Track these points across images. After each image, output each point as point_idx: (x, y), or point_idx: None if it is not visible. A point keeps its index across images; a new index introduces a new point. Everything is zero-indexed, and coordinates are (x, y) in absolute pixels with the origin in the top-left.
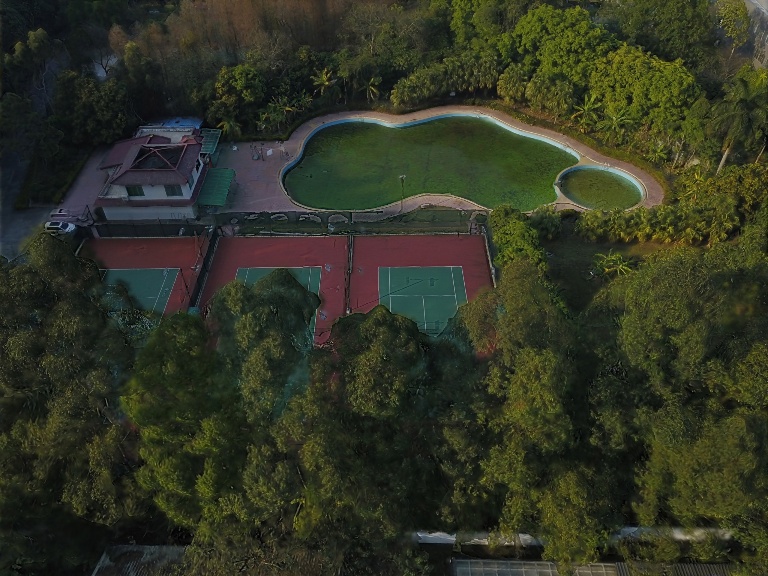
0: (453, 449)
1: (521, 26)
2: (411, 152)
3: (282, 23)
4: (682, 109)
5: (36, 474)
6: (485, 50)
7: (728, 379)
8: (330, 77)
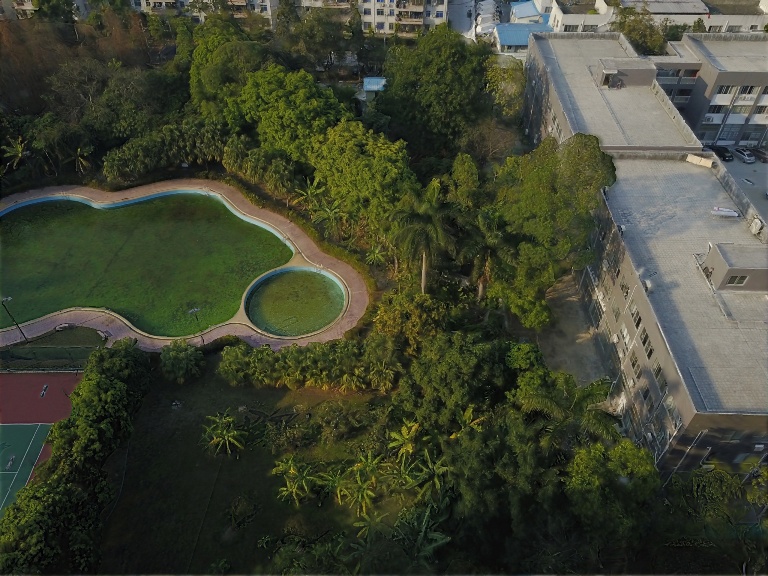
0: None
1: (243, 91)
2: (101, 243)
3: None
4: (395, 204)
5: None
6: (212, 116)
7: None
8: (24, 148)
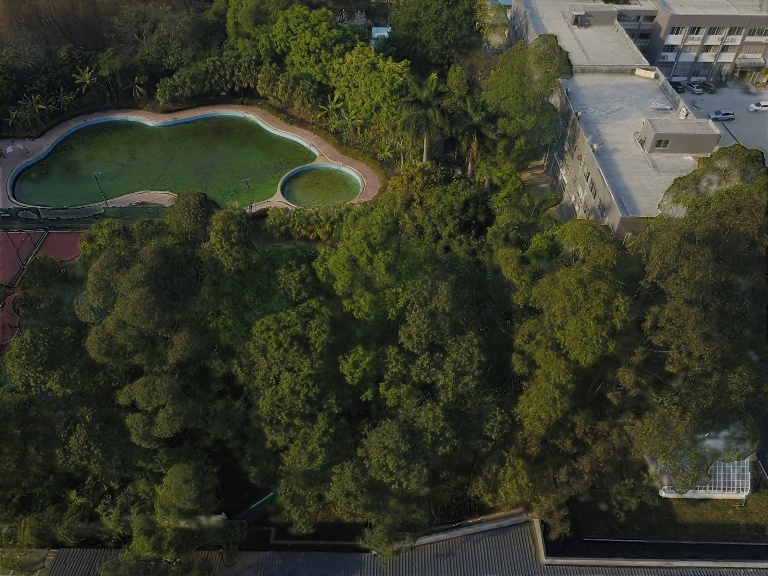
0: None
1: (274, 26)
2: (159, 150)
3: (48, 21)
4: None
5: None
6: (247, 50)
7: None
8: (91, 75)
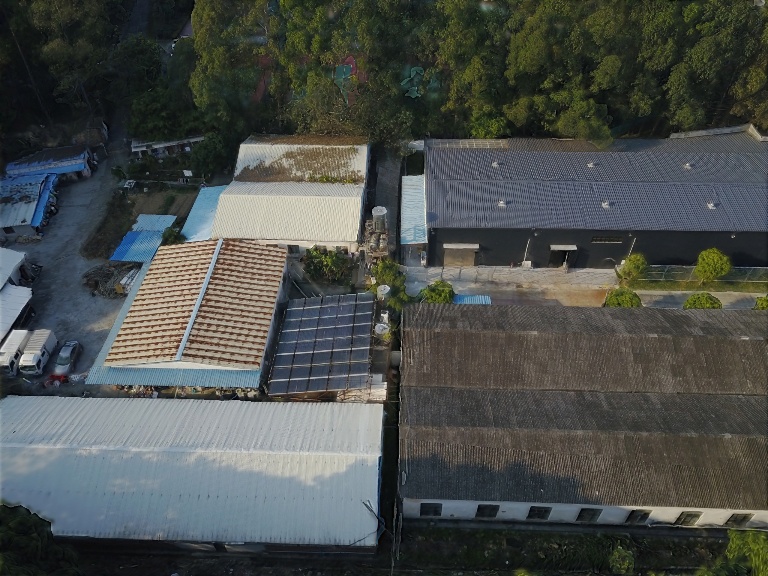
0: (423, 49)
1: None
2: None
3: None
4: None
5: (240, 46)
6: None
7: (541, 3)
8: None
